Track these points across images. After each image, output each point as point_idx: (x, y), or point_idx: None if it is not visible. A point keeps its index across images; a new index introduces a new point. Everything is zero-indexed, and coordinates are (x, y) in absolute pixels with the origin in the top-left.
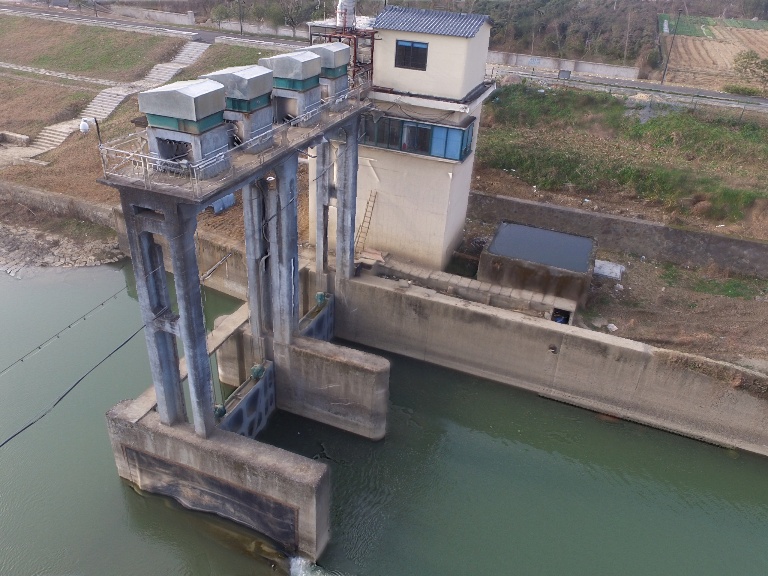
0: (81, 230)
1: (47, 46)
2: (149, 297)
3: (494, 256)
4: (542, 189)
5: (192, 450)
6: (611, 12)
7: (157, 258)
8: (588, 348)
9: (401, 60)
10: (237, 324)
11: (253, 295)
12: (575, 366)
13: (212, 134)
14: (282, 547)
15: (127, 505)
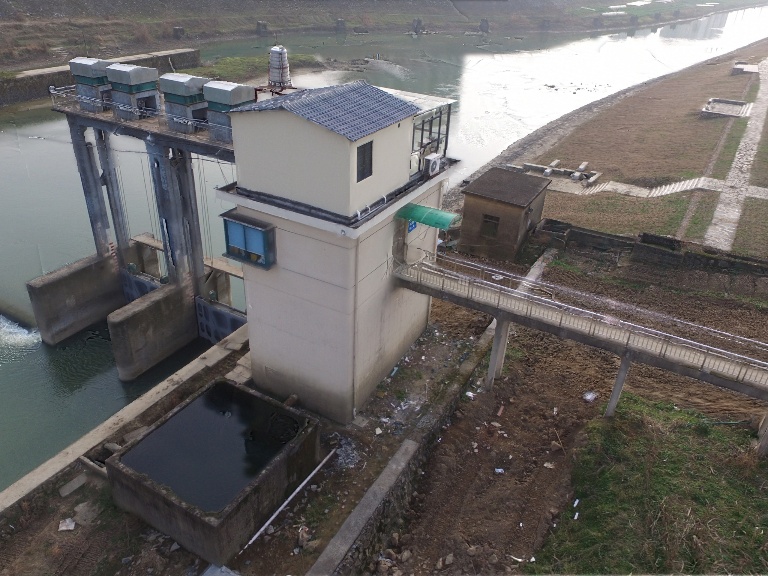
0: None
1: None
2: None
3: (208, 383)
4: (524, 571)
5: None
6: None
7: None
8: None
9: None
10: (209, 263)
11: None
12: None
13: (83, 87)
14: None
15: None
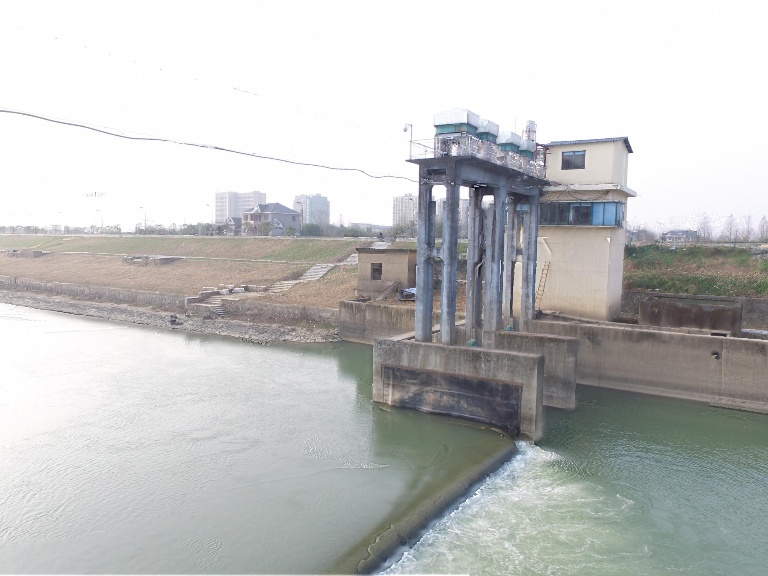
0: (310, 324)
1: (271, 250)
2: (425, 233)
3: (651, 301)
4: None
5: (439, 353)
6: (726, 217)
7: (433, 208)
8: (747, 349)
9: (566, 165)
10: None
11: (469, 292)
12: (739, 369)
13: None
14: (506, 431)
15: (374, 430)
